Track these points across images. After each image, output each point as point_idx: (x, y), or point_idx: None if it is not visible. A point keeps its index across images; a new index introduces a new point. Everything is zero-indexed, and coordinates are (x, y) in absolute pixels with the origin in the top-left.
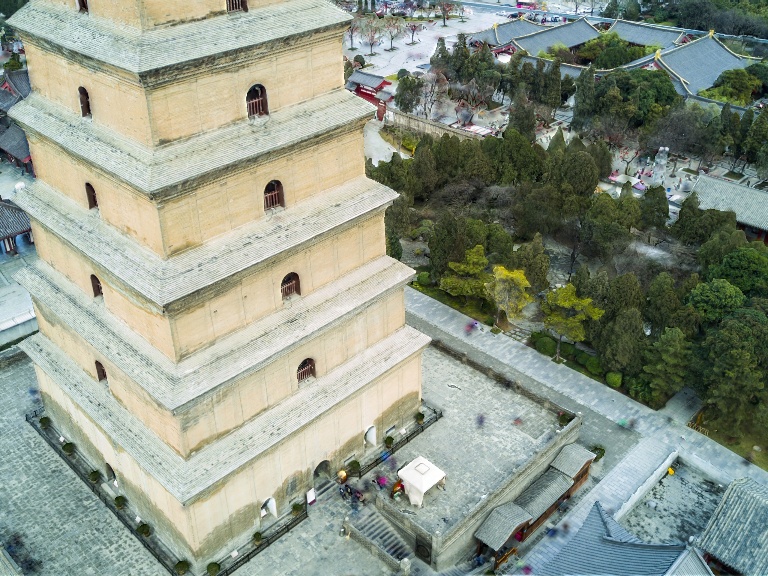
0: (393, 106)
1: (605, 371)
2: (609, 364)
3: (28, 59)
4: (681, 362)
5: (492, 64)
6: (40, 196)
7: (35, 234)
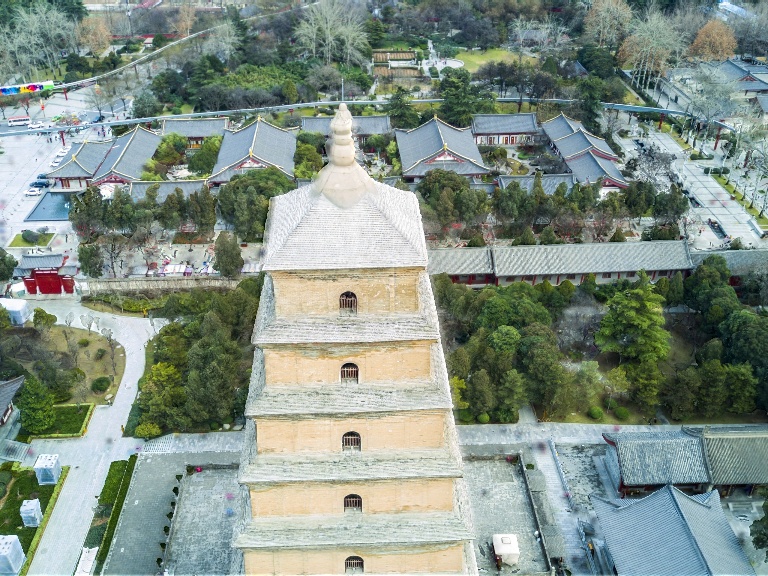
0: (82, 277)
1: (476, 416)
2: (481, 411)
3: (260, 432)
4: (524, 388)
5: (132, 203)
6: (271, 528)
7: (249, 562)
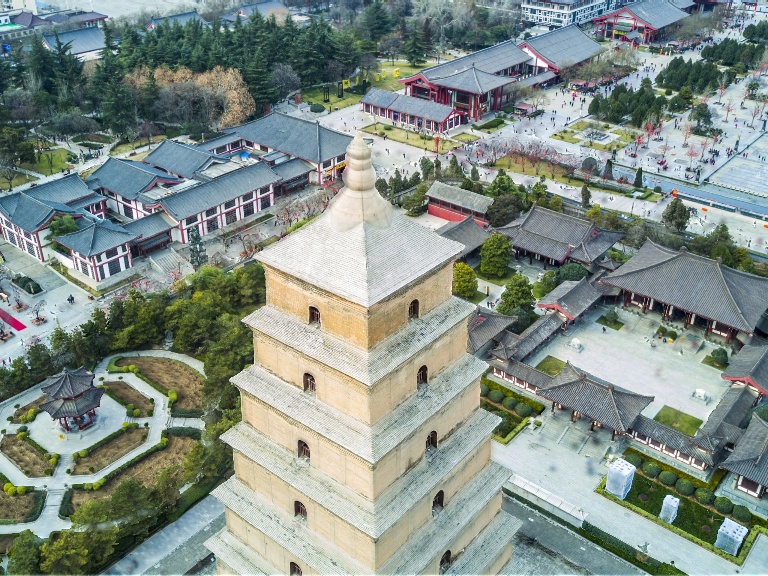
0: None
1: None
2: None
3: None
4: None
5: None
6: None
7: None
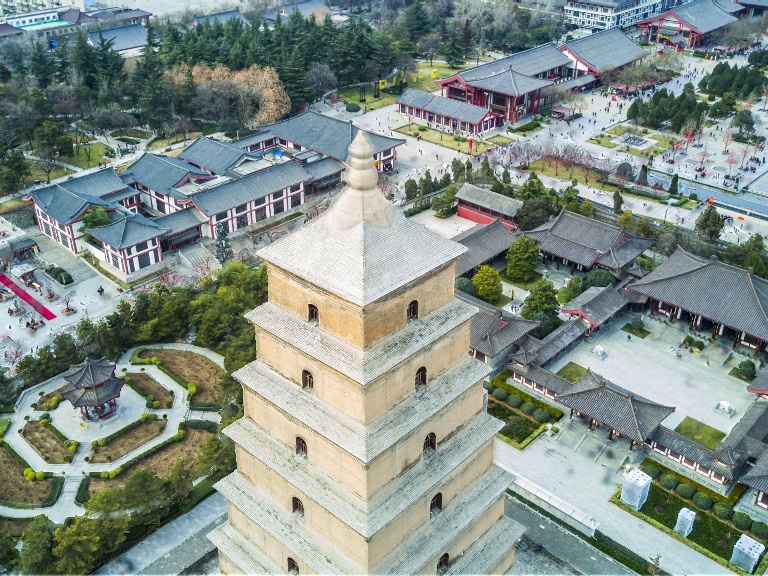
0: None
1: None
2: None
3: None
4: None
5: None
6: None
7: None
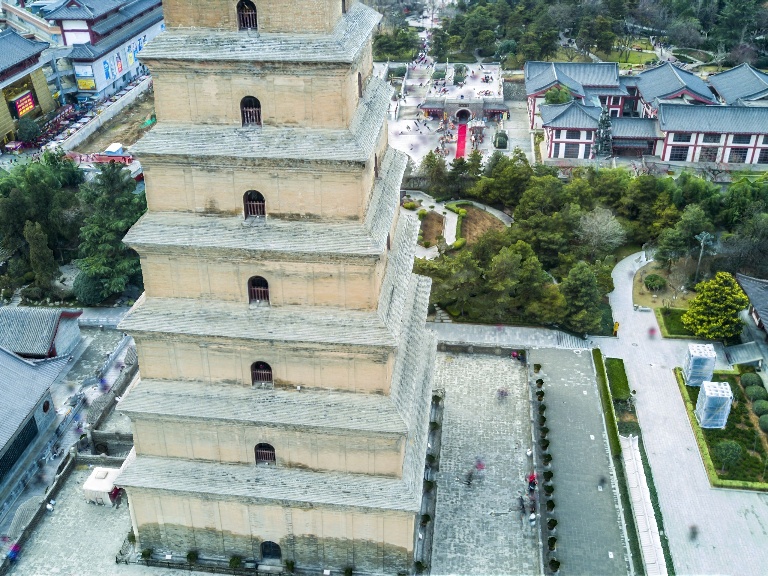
0: None
1: None
2: None
3: None
4: None
5: None
6: None
7: None
